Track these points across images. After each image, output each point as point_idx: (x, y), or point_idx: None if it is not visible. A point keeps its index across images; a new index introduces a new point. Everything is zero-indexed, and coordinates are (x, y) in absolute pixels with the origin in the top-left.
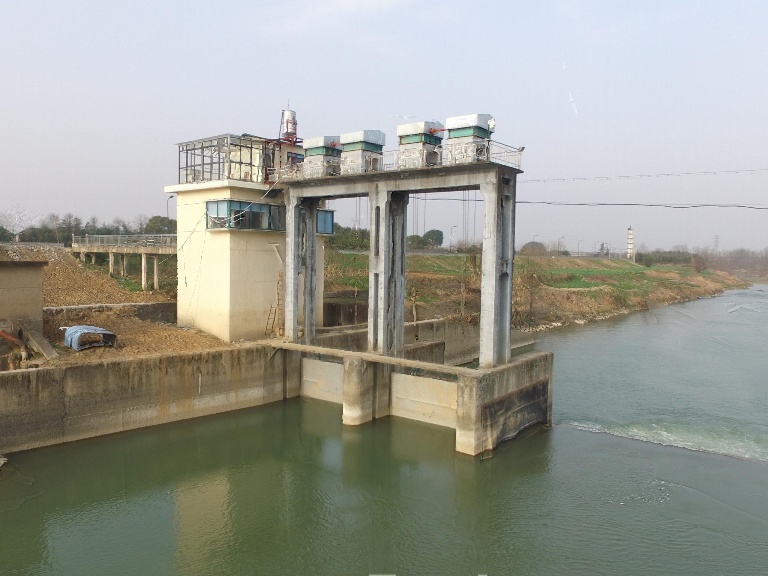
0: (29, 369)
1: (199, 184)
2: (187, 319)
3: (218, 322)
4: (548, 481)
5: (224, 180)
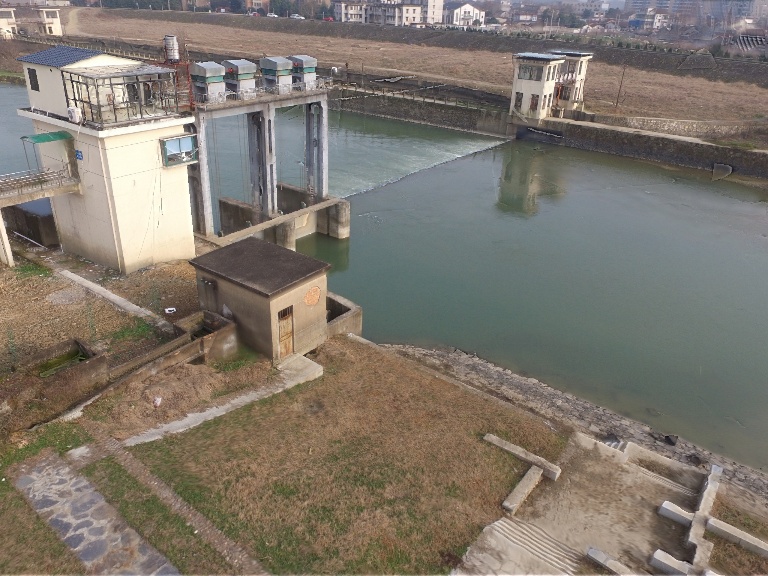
0: (338, 298)
1: (157, 124)
2: (141, 261)
3: (182, 246)
4: (362, 232)
5: (187, 117)
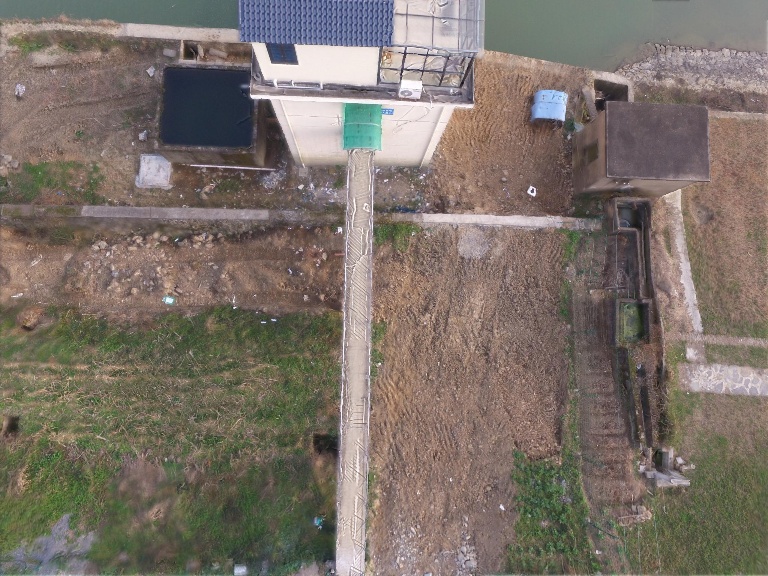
0: (606, 77)
1: None
2: None
3: None
4: None
5: None
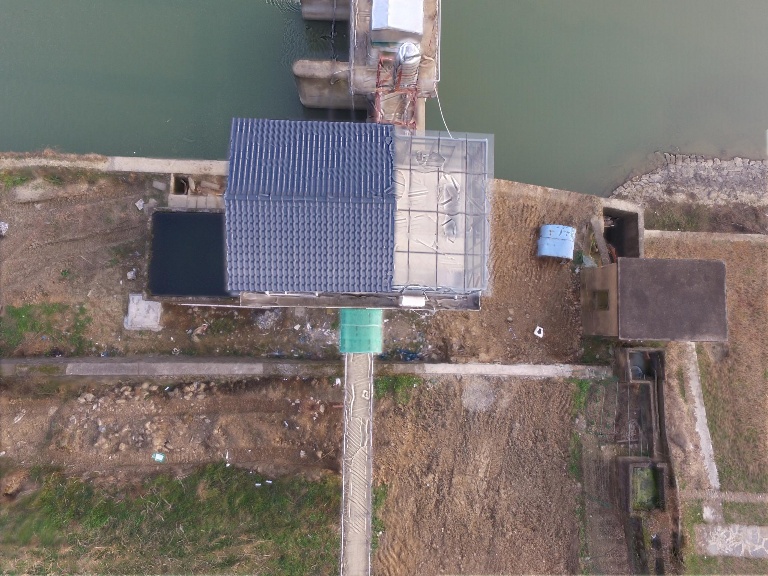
0: (615, 204)
1: None
2: None
3: None
4: None
5: None
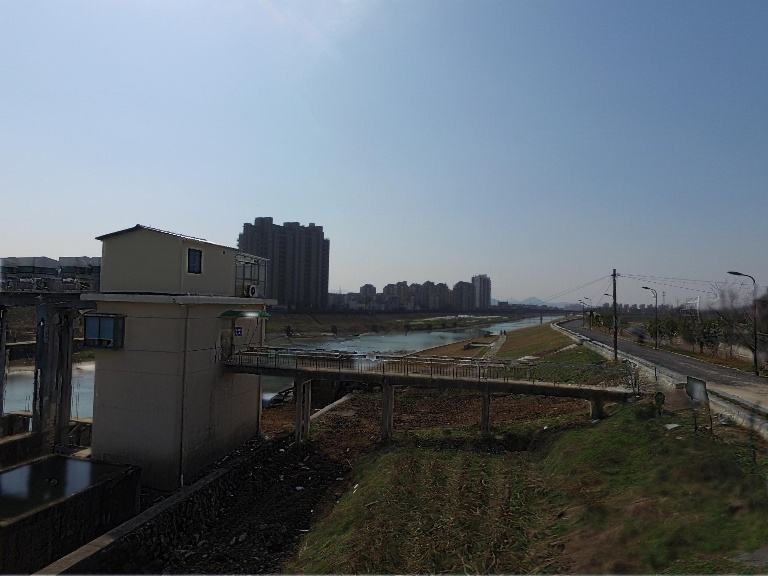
0: None
1: None
2: None
3: None
4: None
5: None
